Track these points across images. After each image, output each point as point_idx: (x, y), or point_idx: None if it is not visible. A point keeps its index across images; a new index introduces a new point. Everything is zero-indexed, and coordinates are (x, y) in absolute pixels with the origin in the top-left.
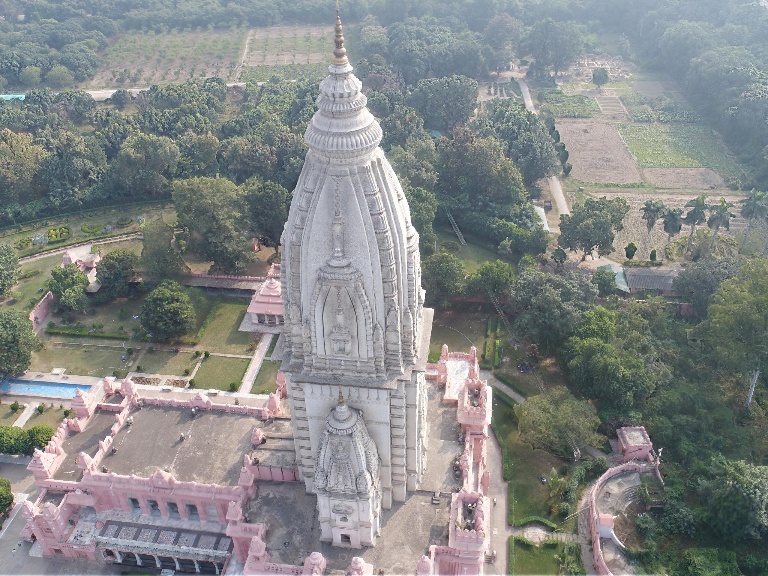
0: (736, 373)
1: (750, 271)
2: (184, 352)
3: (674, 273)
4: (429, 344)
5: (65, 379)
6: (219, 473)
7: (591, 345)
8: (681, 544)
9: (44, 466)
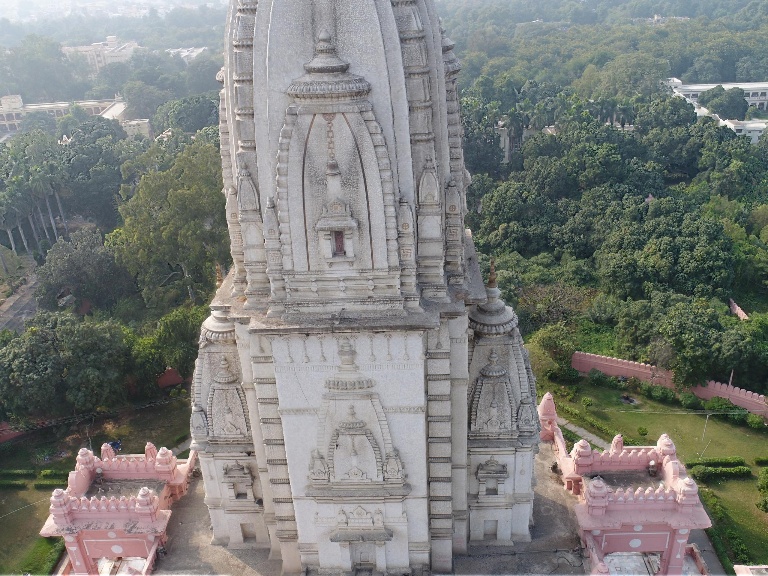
0: (183, 304)
1: (153, 189)
2: None
3: (9, 314)
4: None
5: None
6: None
7: (172, 323)
8: None
9: None
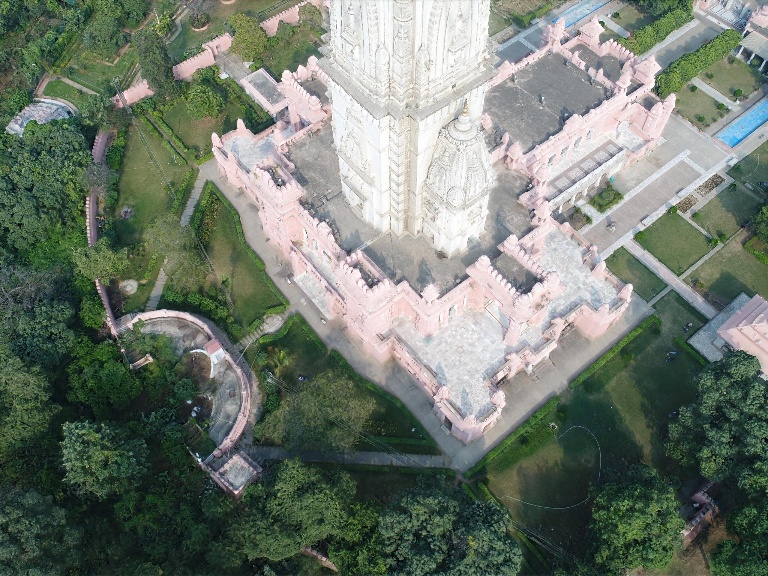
0: None
1: None
2: (738, 231)
3: None
4: (340, 83)
5: (760, 136)
6: (485, 106)
7: None
8: (151, 407)
9: (584, 26)
